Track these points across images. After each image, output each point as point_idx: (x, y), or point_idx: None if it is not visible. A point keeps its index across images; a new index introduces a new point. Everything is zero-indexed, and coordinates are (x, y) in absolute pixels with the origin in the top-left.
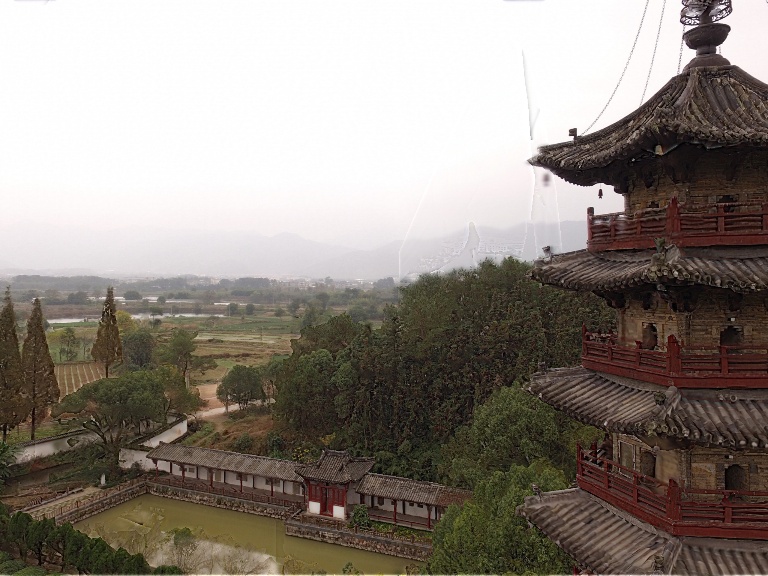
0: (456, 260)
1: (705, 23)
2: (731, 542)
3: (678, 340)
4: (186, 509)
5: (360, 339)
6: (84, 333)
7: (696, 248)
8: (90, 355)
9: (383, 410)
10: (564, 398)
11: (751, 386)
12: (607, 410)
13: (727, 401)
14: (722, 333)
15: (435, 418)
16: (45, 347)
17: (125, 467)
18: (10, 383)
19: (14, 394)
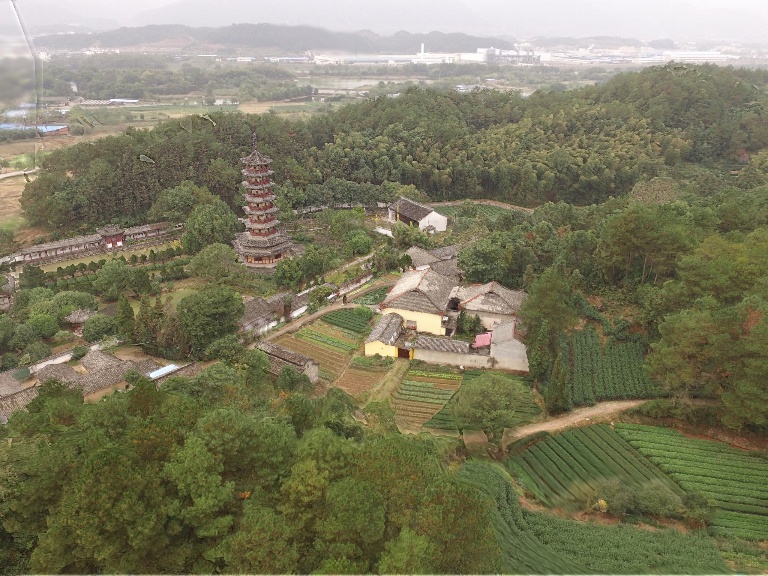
0: (82, 138)
1: None
2: None
3: None
4: None
5: None
6: None
7: None
8: None
9: None
10: None
11: None
12: None
13: None
14: None
15: (124, 207)
16: None
17: None
18: None
19: None
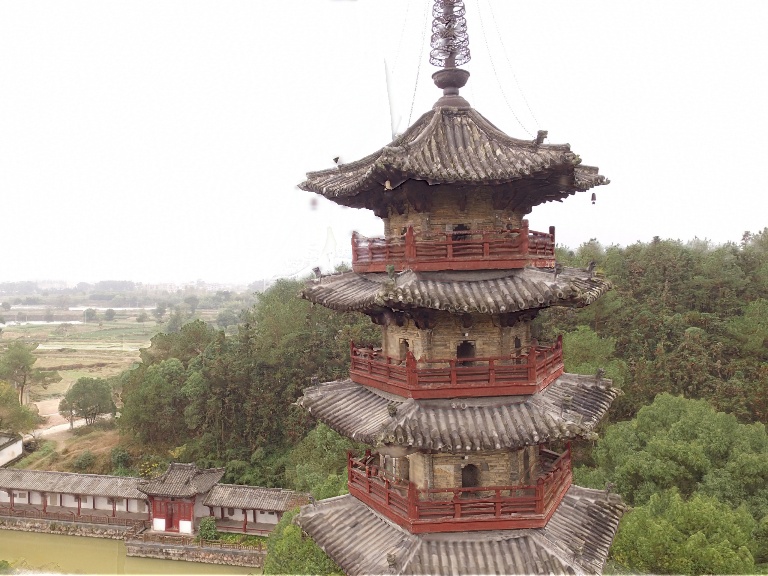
0: (314, 264)
1: (451, 66)
2: (463, 534)
3: (422, 355)
4: (14, 539)
5: (214, 346)
6: None
7: (432, 272)
8: None
9: (236, 418)
10: (329, 411)
11: (475, 395)
12: (361, 422)
13: (458, 409)
14: (459, 347)
15: (288, 423)
16: None
17: None
18: None
19: None
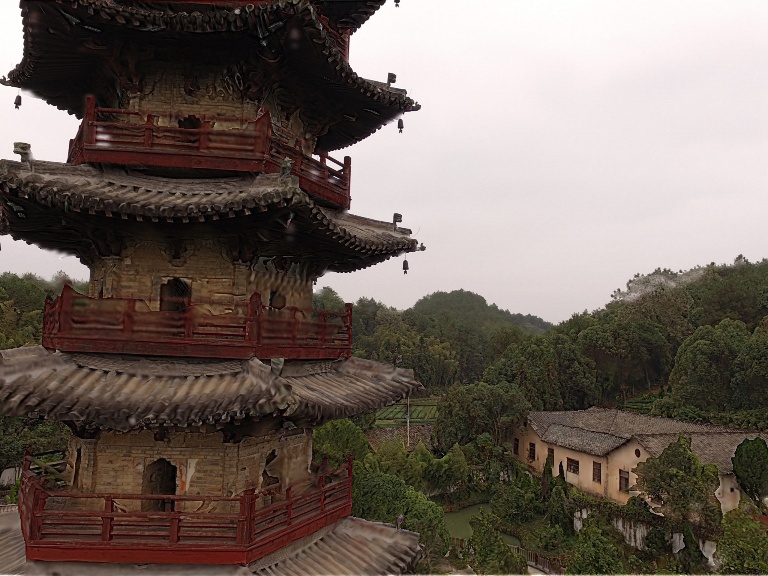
0: None
1: None
2: None
3: None
4: None
5: None
6: None
7: None
8: None
9: None
10: None
11: None
12: None
13: None
14: None
15: None
16: None
17: None
18: None
19: None
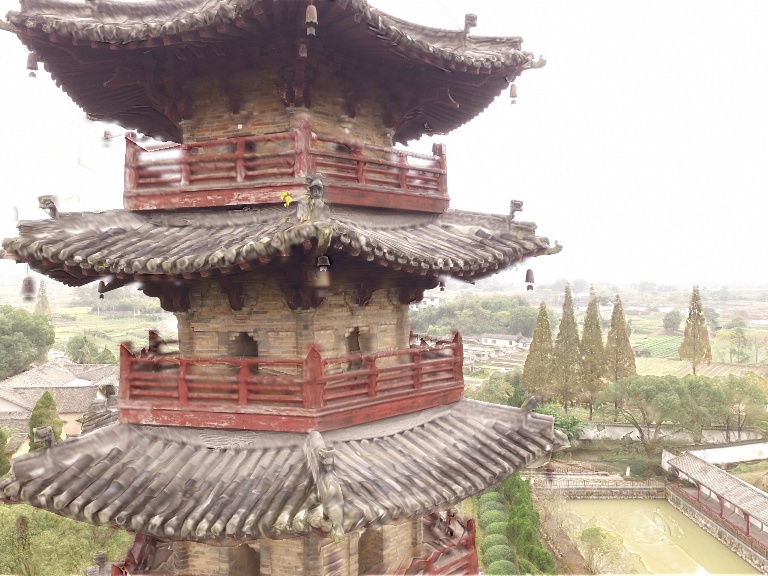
0: None
1: None
2: None
3: None
4: (693, 530)
5: None
6: (755, 335)
7: None
8: (767, 359)
9: None
10: None
11: None
12: None
13: None
14: None
15: None
16: (625, 340)
17: (665, 469)
18: (592, 368)
19: (595, 378)
